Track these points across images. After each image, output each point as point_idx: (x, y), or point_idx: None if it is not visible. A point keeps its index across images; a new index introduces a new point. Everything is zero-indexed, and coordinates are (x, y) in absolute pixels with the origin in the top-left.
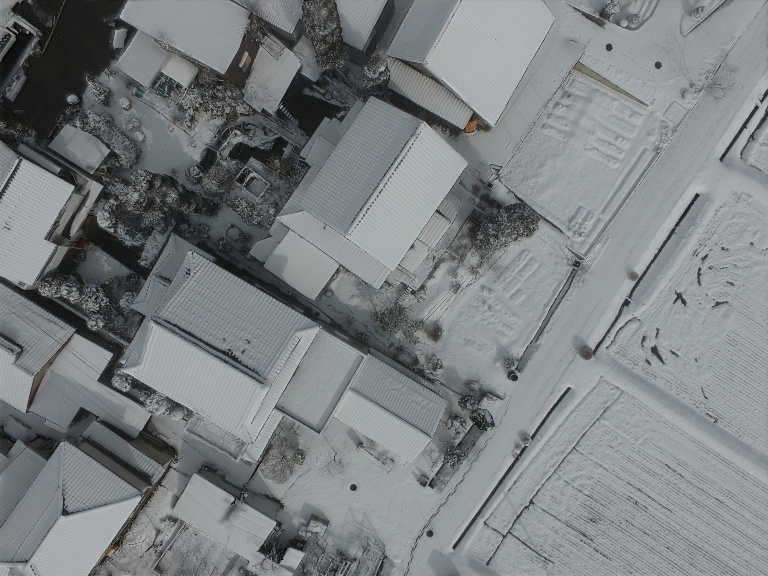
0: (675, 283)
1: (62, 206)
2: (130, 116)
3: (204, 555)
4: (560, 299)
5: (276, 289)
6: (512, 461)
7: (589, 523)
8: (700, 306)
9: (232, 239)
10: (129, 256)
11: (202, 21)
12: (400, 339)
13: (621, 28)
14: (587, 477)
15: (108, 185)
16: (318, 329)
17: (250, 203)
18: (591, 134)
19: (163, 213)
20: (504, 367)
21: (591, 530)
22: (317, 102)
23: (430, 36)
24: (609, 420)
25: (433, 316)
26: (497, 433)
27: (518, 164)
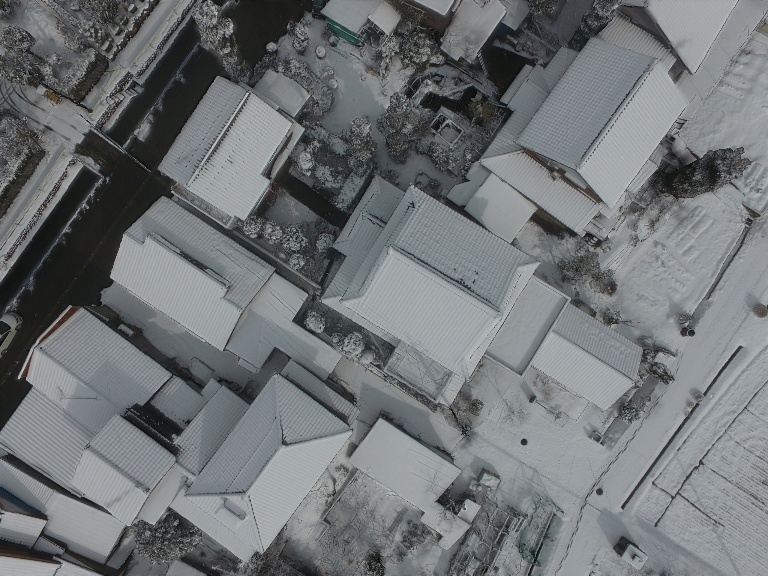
0: None
1: (279, 142)
2: (323, 65)
3: (372, 508)
4: (731, 257)
5: None
6: (683, 420)
7: (761, 485)
8: None
9: None
10: (317, 202)
11: None
12: None
13: None
14: (759, 438)
15: (307, 129)
16: (537, 265)
17: (443, 150)
18: None
19: (370, 153)
20: (678, 323)
21: (763, 493)
22: (506, 54)
23: None
24: None
25: None
26: (669, 390)
27: (694, 121)
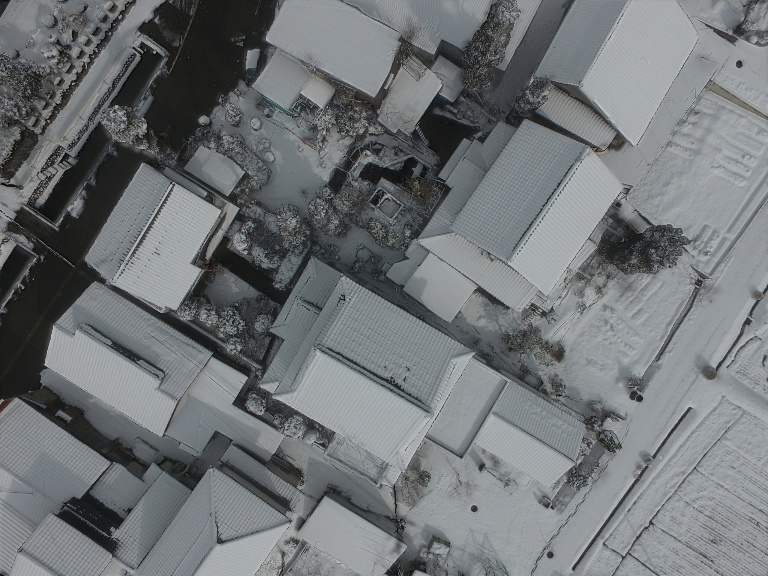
0: None
1: (209, 230)
2: (259, 136)
3: None
4: (681, 318)
5: (406, 310)
6: (632, 482)
7: (710, 544)
8: None
9: (362, 260)
10: (257, 277)
11: (351, 43)
12: (524, 359)
13: (751, 45)
14: (708, 498)
15: (242, 207)
16: None
17: (383, 224)
18: (718, 152)
19: (305, 236)
20: (627, 387)
21: (712, 551)
22: (447, 122)
23: (585, 58)
24: (731, 440)
25: (556, 336)
26: (618, 454)
27: (643, 182)
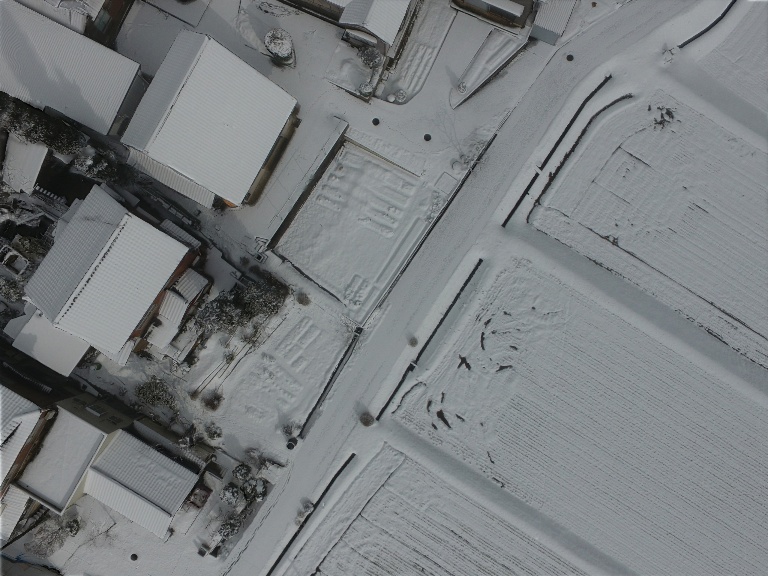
0: (459, 348)
1: None
2: None
3: None
4: (343, 365)
5: None
6: (297, 528)
7: None
8: (484, 370)
9: None
10: None
11: None
12: None
13: (387, 103)
14: (373, 544)
15: None
16: (40, 413)
17: (11, 280)
18: (364, 205)
19: None
20: (284, 434)
21: None
22: (83, 180)
23: (153, 126)
24: (393, 486)
25: (211, 385)
26: (280, 500)
27: (294, 234)
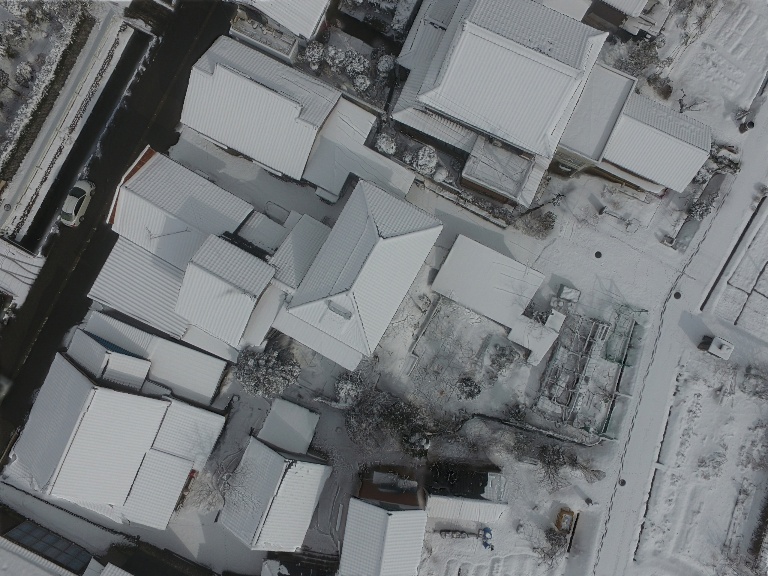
0: None
1: None
2: None
3: (457, 337)
4: None
5: None
6: (750, 216)
7: None
8: None
9: None
10: (369, 34)
11: None
12: None
13: None
14: None
15: None
16: (606, 36)
17: None
18: None
19: None
20: (735, 120)
21: None
22: None
23: None
24: None
25: (661, 75)
26: (733, 188)
27: None
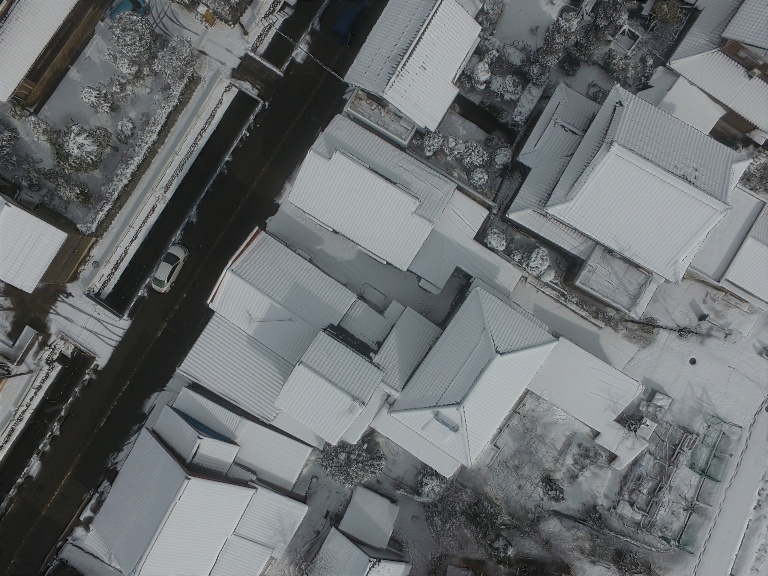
0: None
1: (469, 48)
2: None
3: (540, 432)
4: None
5: None
6: None
7: None
8: None
9: None
10: (484, 119)
11: None
12: None
13: None
14: None
15: None
16: (749, 162)
17: None
18: None
19: (557, 59)
20: None
21: None
22: None
23: None
24: None
25: None
26: None
27: None
